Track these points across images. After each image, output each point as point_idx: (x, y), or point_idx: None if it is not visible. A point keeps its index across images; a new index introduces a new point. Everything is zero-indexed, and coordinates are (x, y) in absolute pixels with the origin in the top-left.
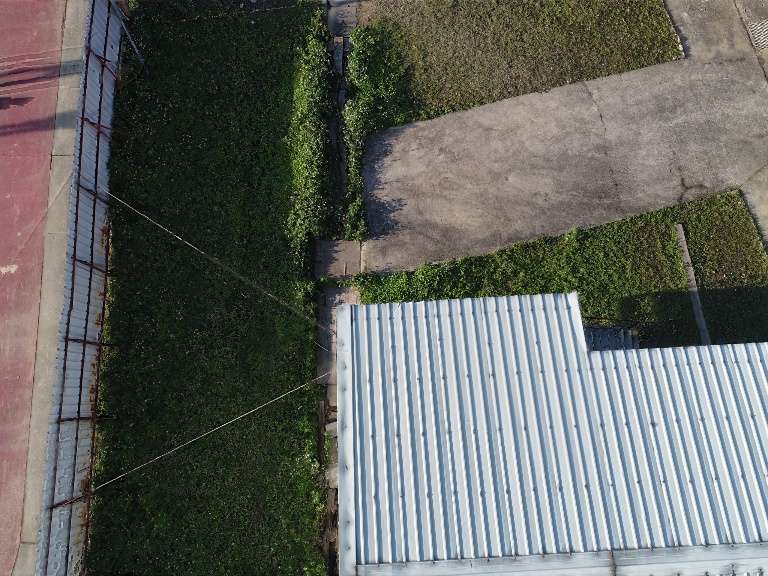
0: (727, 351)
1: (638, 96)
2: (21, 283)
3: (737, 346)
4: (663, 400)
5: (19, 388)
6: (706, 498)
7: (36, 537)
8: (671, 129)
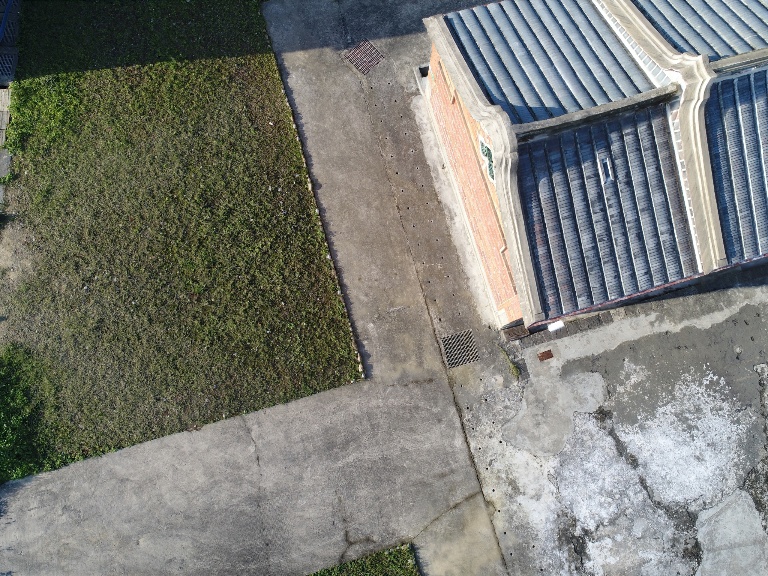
0: None
1: (305, 430)
2: None
3: None
4: None
5: None
6: None
7: None
8: (339, 470)
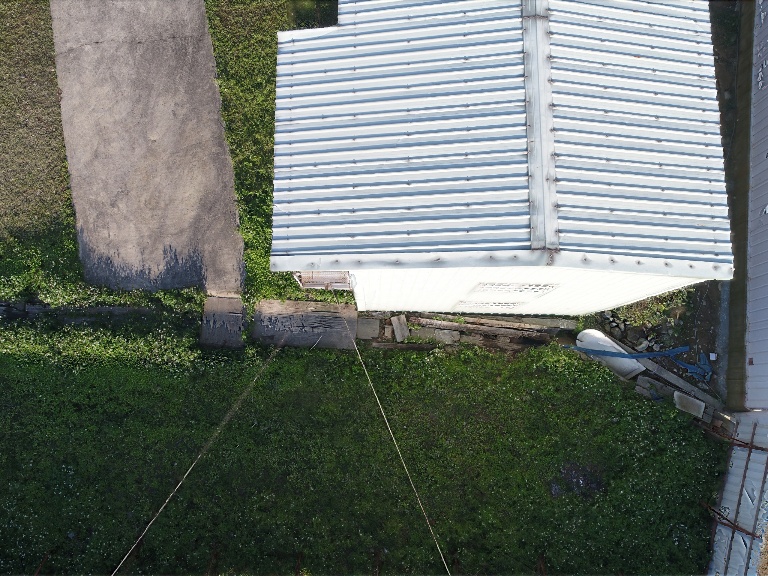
0: None
1: (80, 5)
2: None
3: None
4: None
5: None
6: None
7: None
8: None
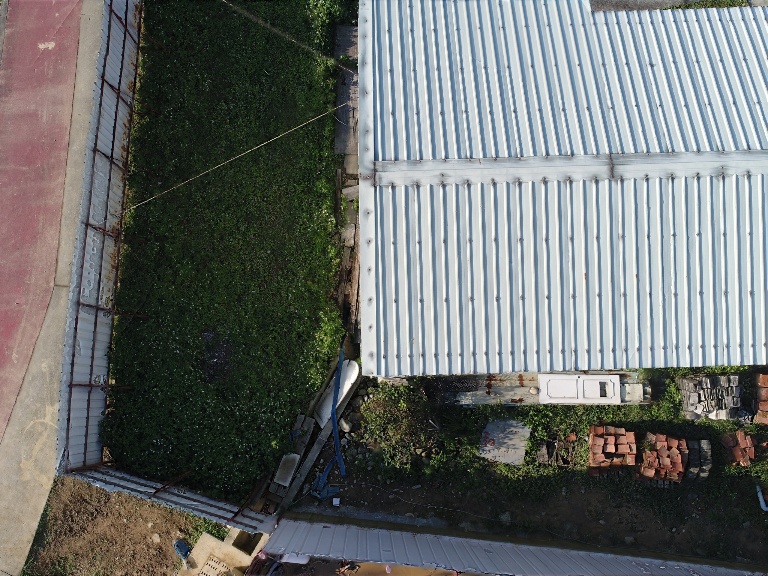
0: (723, 13)
1: None
2: (58, 58)
3: (732, 9)
4: (661, 47)
5: (55, 150)
6: (699, 118)
7: (69, 281)
8: None
